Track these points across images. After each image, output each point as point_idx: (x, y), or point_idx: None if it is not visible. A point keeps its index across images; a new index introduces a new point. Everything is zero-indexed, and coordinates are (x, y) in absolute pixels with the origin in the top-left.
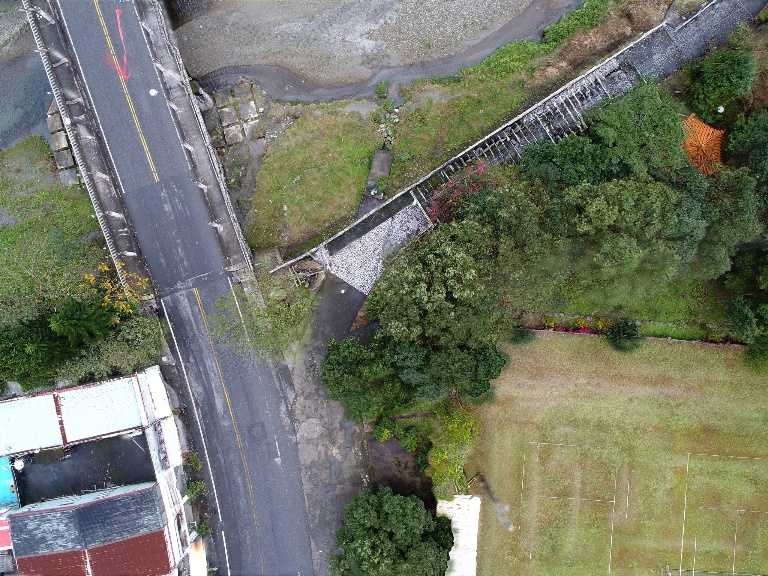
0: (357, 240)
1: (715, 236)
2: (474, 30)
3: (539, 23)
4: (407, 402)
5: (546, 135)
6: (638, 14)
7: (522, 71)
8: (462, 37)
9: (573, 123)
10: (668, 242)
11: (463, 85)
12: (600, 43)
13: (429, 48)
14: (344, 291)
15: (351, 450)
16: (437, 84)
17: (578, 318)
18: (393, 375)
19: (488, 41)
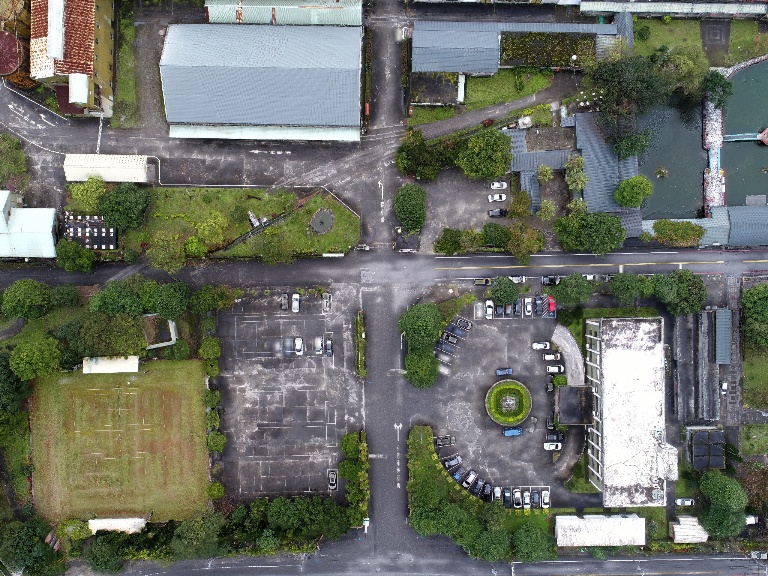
0: (7, 568)
1: None
2: None
3: None
4: (43, 559)
5: None
6: None
7: None
8: None
9: None
10: None
11: None
12: None
13: None
14: (27, 571)
15: (88, 562)
16: None
17: None
18: (31, 568)
19: None
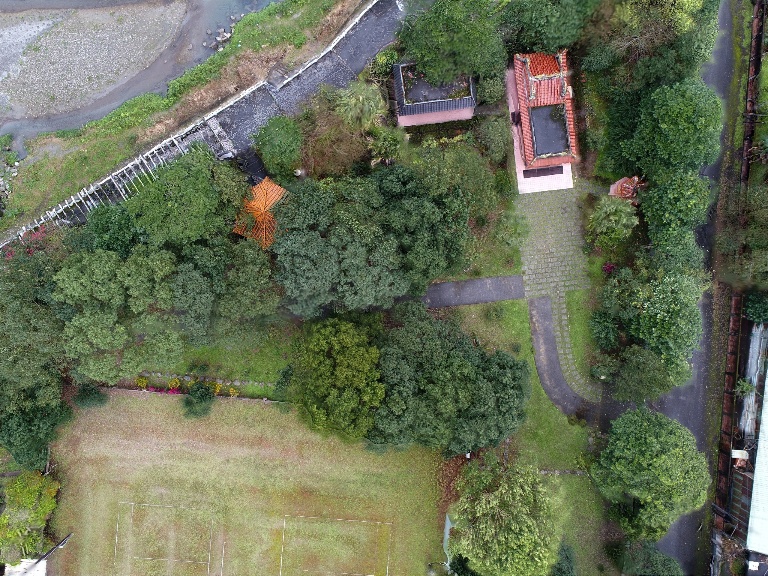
0: None
1: (216, 311)
2: (99, 83)
3: (167, 76)
4: None
5: (120, 197)
6: (244, 72)
7: (140, 126)
8: (87, 90)
9: (149, 185)
10: (171, 316)
11: (82, 139)
12: (208, 100)
13: (53, 101)
14: None
15: None
16: (59, 138)
17: (174, 378)
18: None
19: (115, 94)
